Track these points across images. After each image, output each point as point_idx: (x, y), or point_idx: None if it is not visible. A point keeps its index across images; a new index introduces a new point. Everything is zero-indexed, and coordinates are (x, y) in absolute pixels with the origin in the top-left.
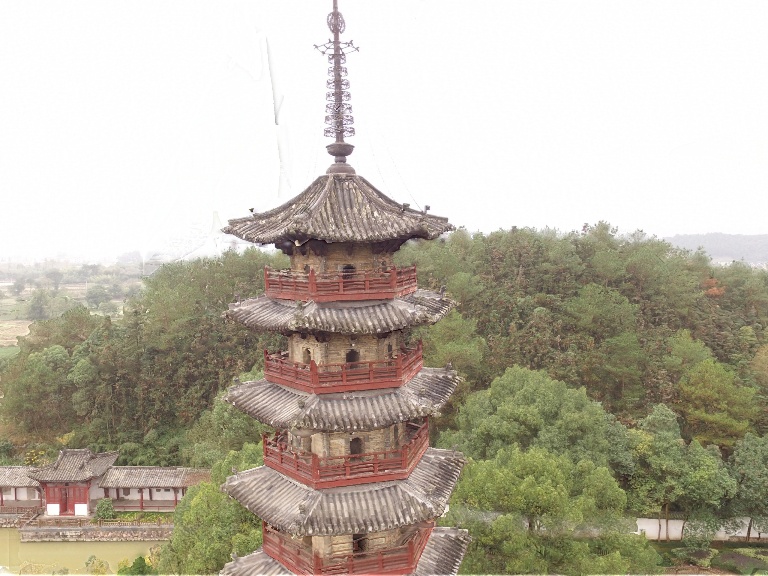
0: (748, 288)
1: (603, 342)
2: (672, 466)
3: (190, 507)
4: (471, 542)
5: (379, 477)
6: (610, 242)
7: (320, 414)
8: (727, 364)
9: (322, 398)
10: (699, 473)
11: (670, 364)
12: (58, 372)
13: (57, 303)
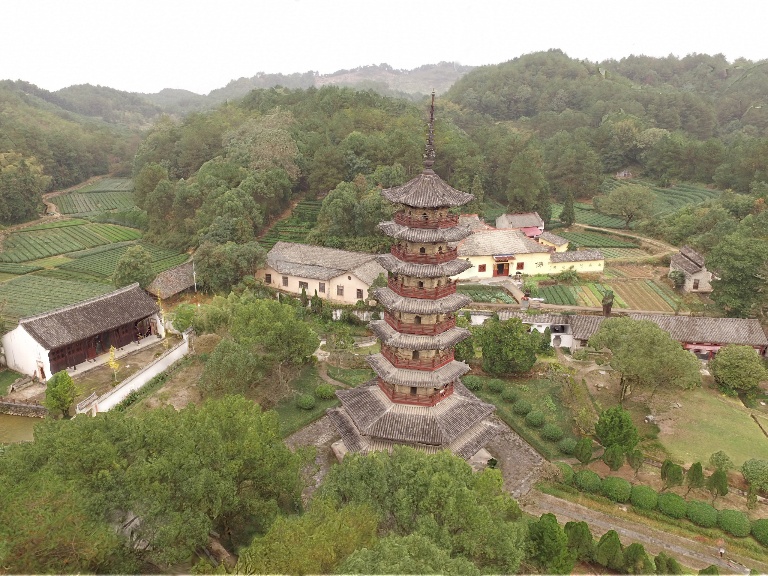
0: None
1: None
2: None
3: None
4: None
5: None
6: None
7: None
8: None
9: None
10: None
11: None
12: None
13: None
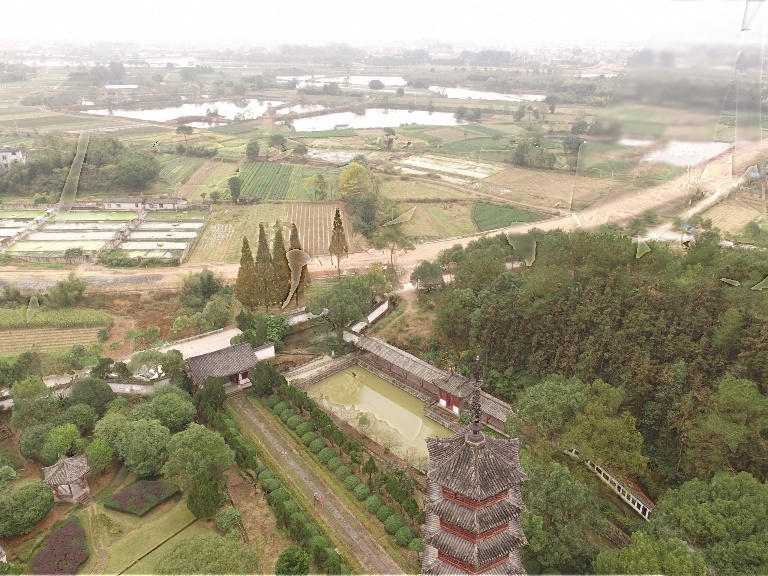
0: None
1: None
2: None
3: None
4: None
5: (463, 569)
6: None
7: (438, 539)
8: None
9: None
10: None
11: None
12: (466, 310)
13: (535, 154)
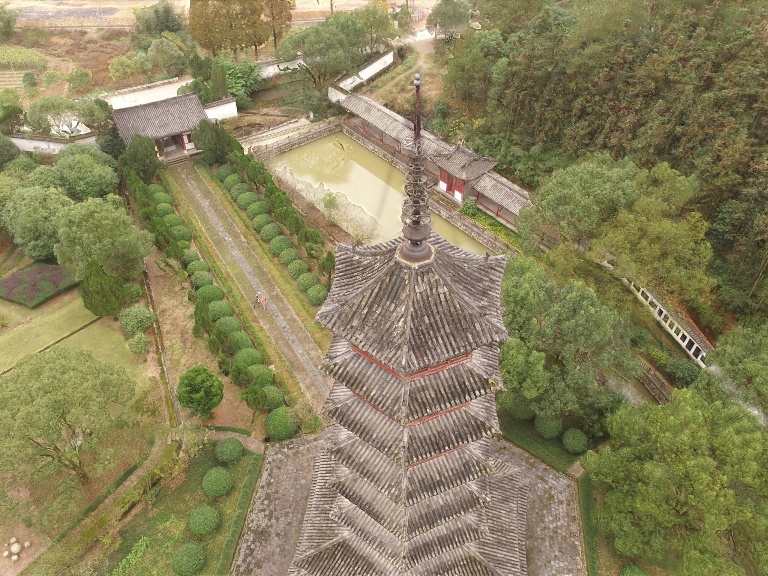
0: None
1: None
2: None
3: None
4: (630, 455)
5: None
6: None
7: (347, 410)
8: None
9: None
10: None
11: None
12: (487, 60)
13: None
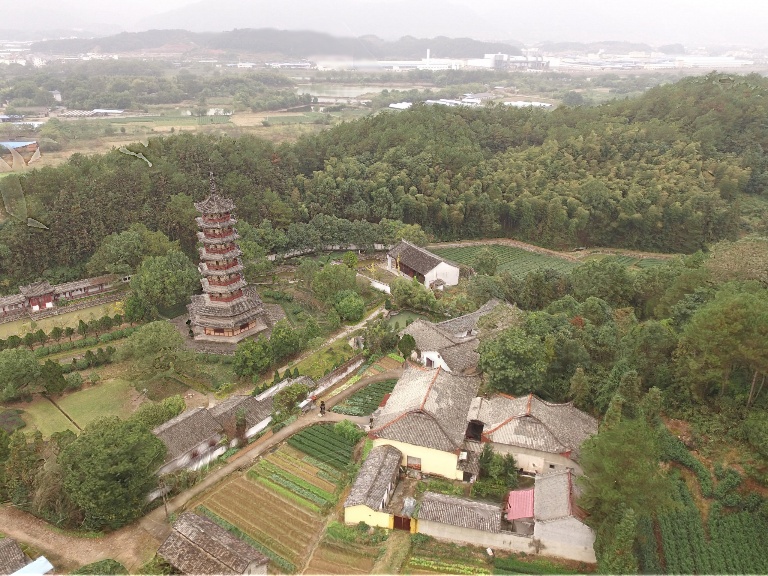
0: (289, 157)
1: (243, 198)
2: (271, 238)
3: (141, 279)
4: None
5: None
6: (234, 148)
7: None
8: (284, 196)
9: (221, 238)
10: (279, 238)
11: (266, 202)
12: None
13: None
